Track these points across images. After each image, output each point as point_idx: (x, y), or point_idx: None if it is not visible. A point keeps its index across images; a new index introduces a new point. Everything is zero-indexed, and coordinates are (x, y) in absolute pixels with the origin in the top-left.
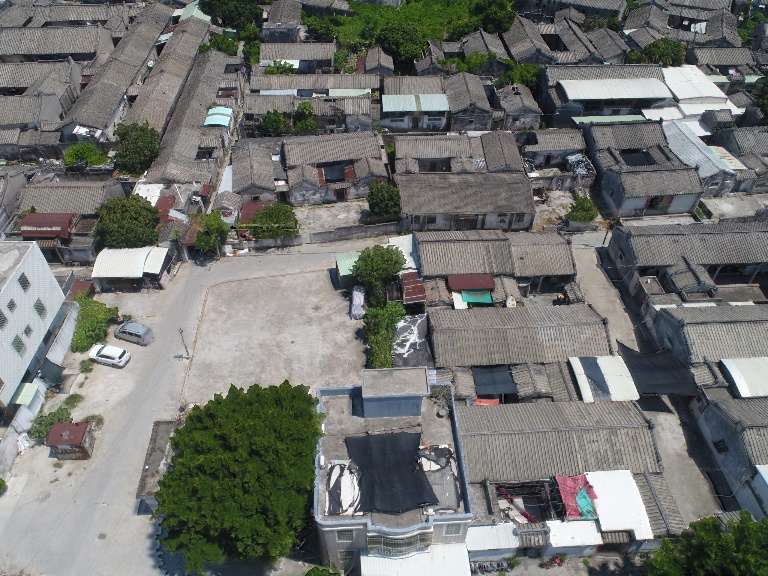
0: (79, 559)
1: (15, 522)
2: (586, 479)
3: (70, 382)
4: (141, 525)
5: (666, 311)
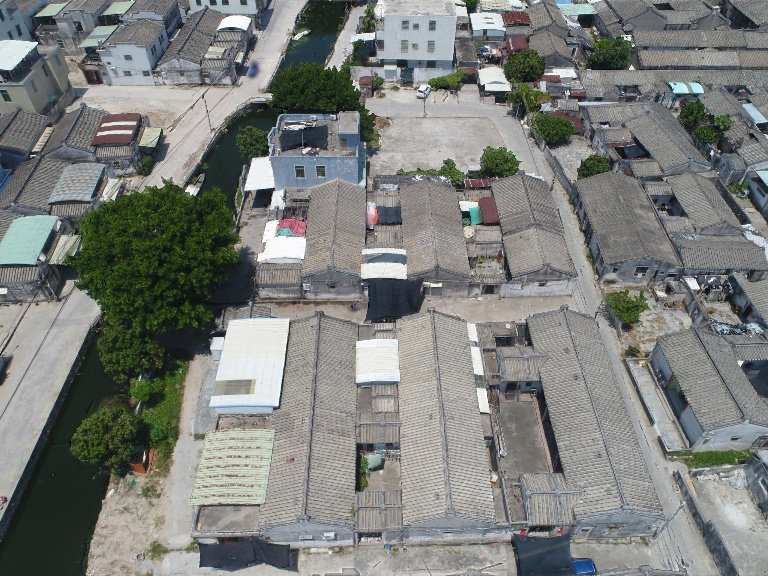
0: None
1: None
2: None
3: (408, 86)
4: None
5: (456, 316)
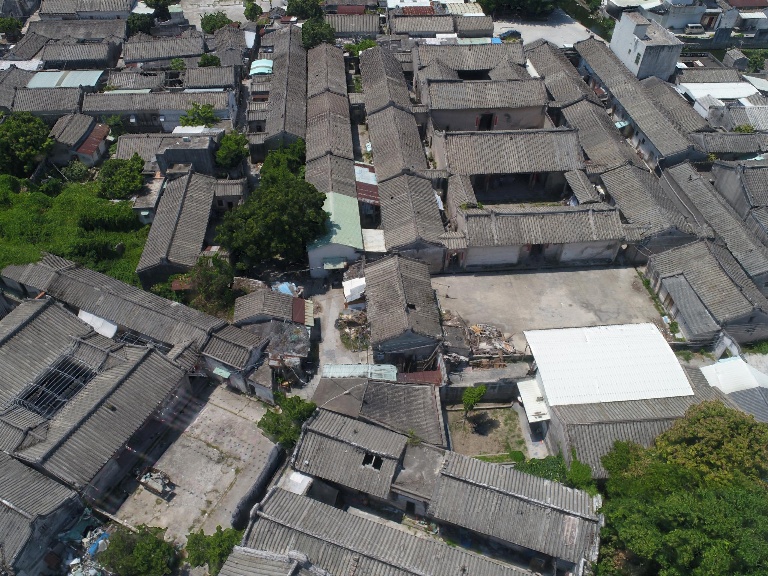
0: None
1: None
2: None
3: None
4: None
5: None
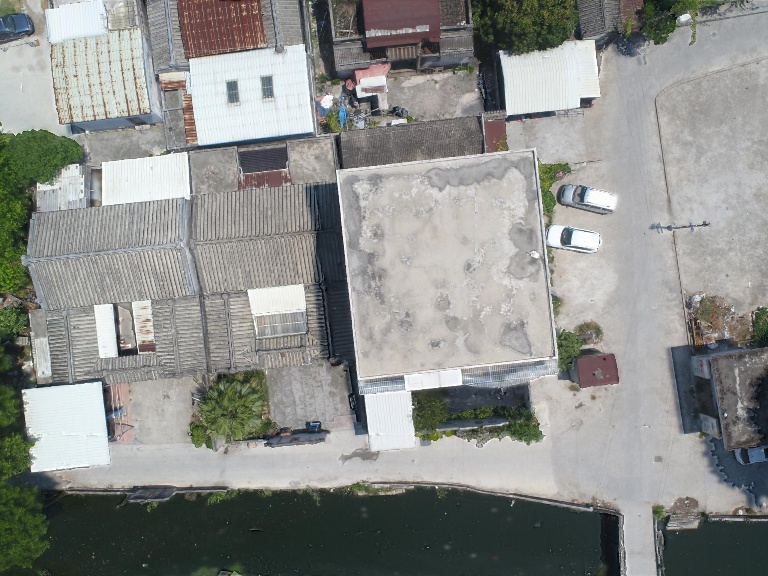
0: (645, 483)
1: (560, 452)
2: None
3: None
4: (693, 444)
5: None
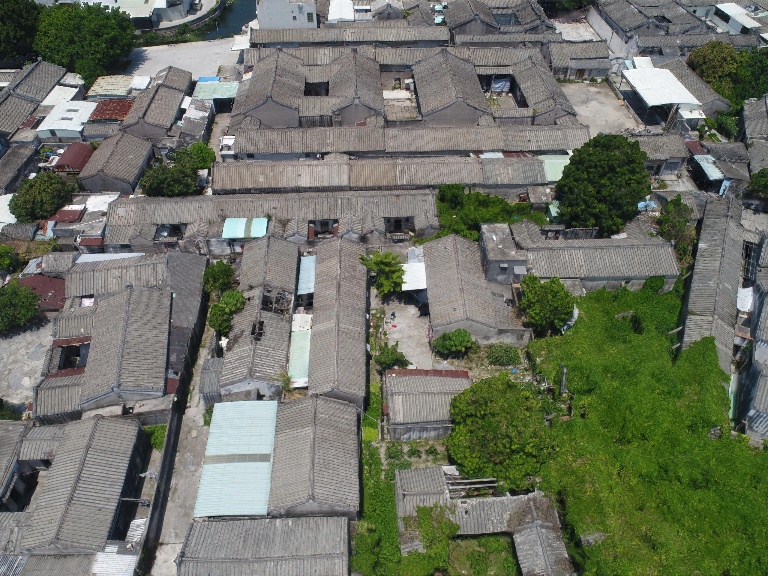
0: None
1: None
2: None
3: None
4: None
5: None
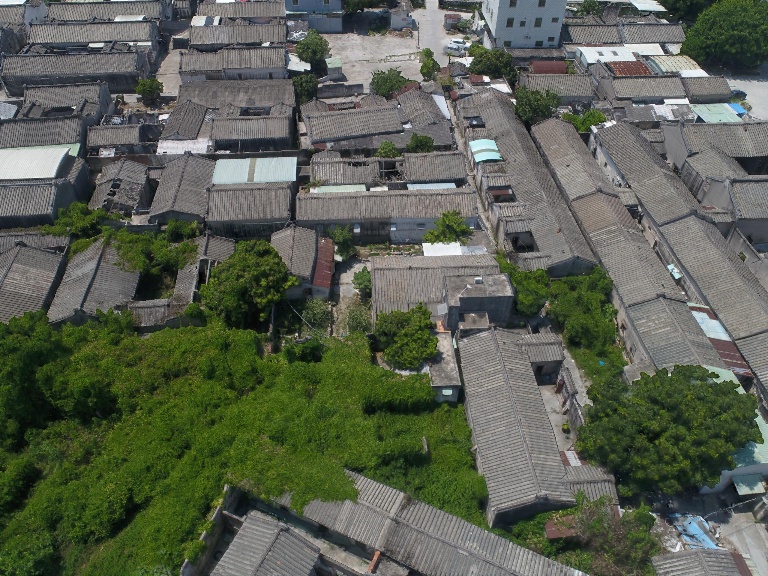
0: (429, 12)
1: None
2: (235, 1)
3: None
4: None
5: None
